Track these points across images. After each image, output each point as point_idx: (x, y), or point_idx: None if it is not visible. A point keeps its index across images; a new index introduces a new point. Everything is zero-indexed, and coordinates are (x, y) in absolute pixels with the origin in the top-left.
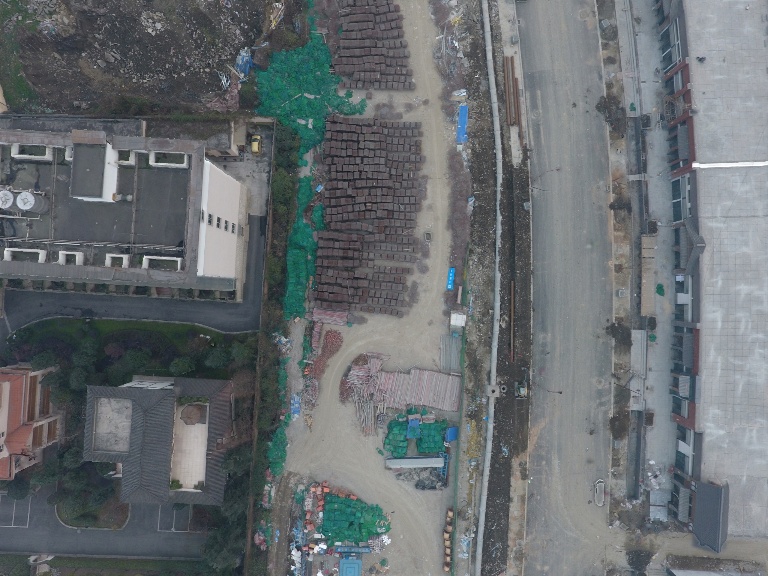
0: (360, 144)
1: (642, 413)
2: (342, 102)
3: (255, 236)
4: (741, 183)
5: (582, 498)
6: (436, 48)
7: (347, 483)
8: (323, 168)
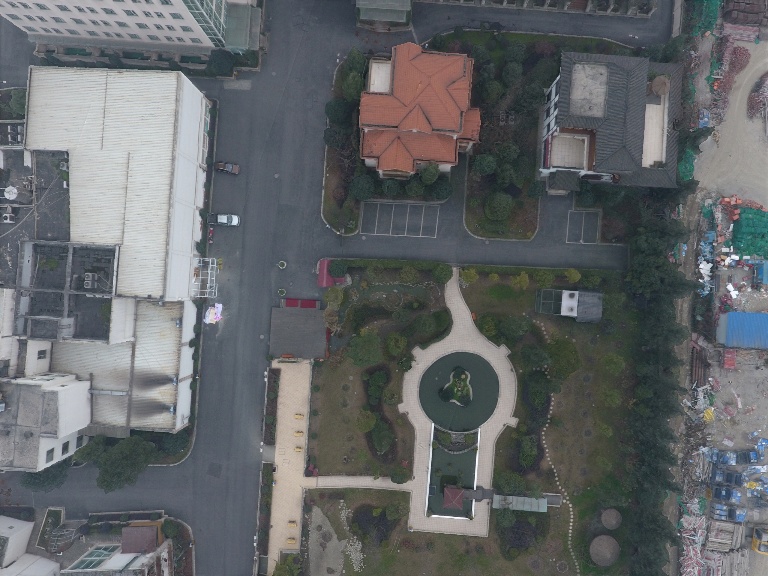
0: None
1: None
2: None
3: None
4: None
5: None
6: None
7: (755, 198)
8: None
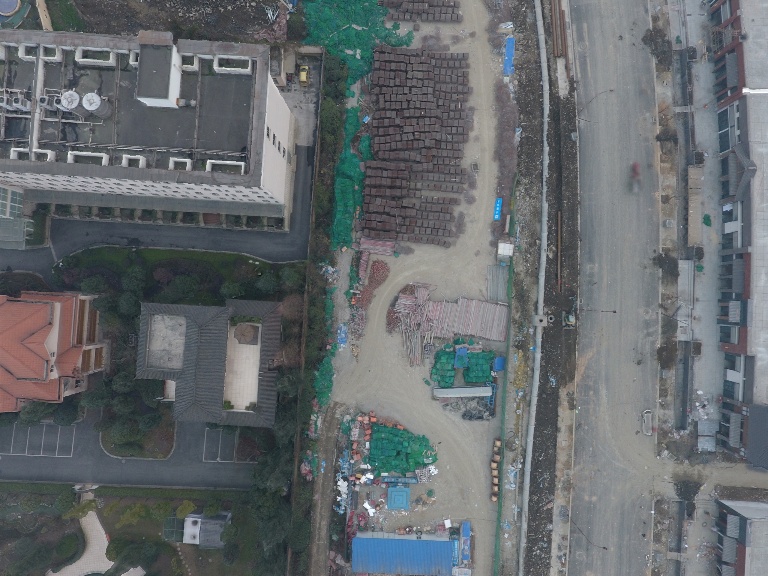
0: (408, 74)
1: (690, 343)
2: (390, 33)
3: (302, 166)
4: None
5: (630, 428)
6: None
7: (393, 413)
8: (371, 98)
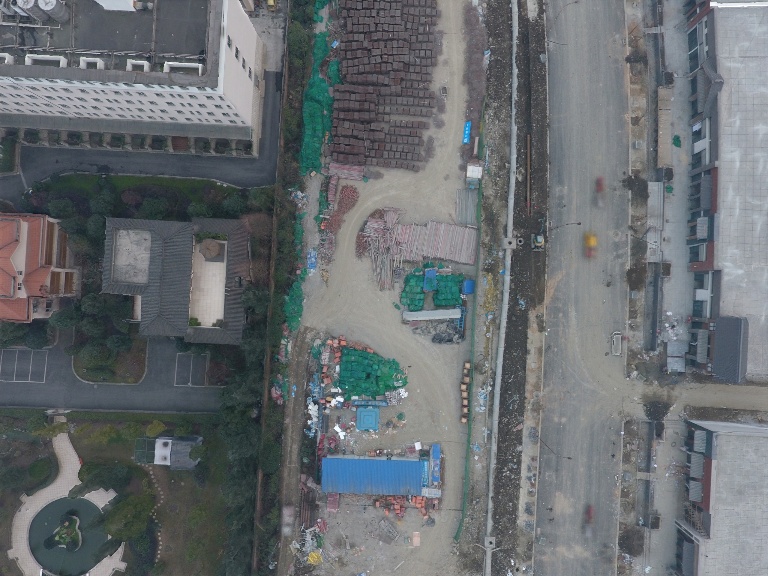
0: None
1: (659, 264)
2: None
3: (271, 92)
4: (759, 24)
5: (599, 350)
6: None
7: (364, 338)
8: (339, 22)
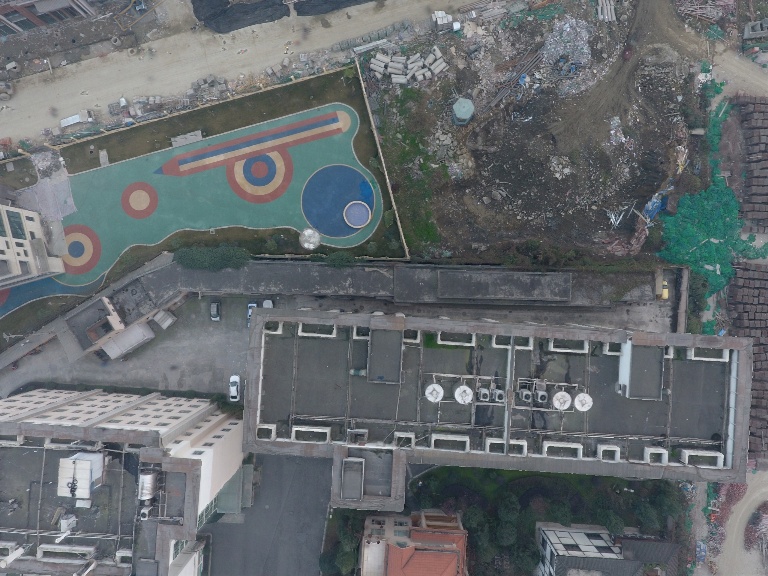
0: None
1: None
2: (748, 247)
3: None
4: None
5: None
6: None
7: None
8: (732, 315)
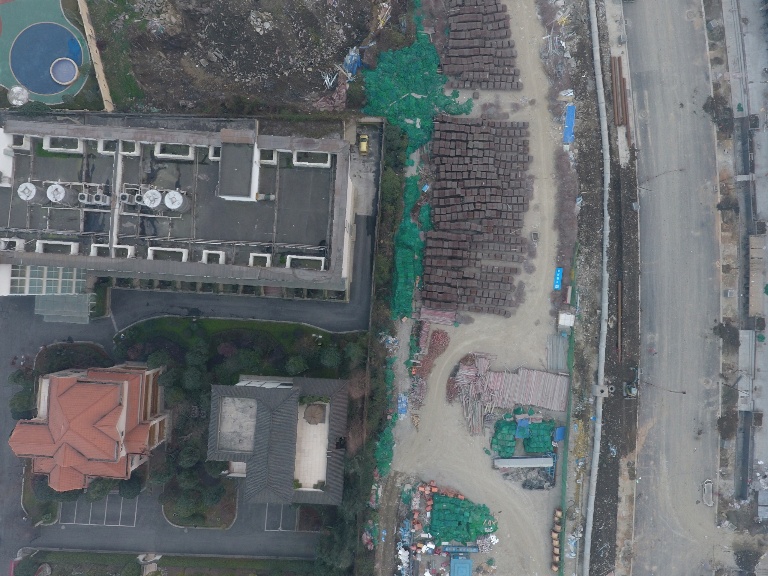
0: (469, 144)
1: (751, 413)
2: (449, 102)
3: (362, 236)
4: None
5: (690, 498)
6: (543, 48)
7: (454, 483)
8: (431, 168)
